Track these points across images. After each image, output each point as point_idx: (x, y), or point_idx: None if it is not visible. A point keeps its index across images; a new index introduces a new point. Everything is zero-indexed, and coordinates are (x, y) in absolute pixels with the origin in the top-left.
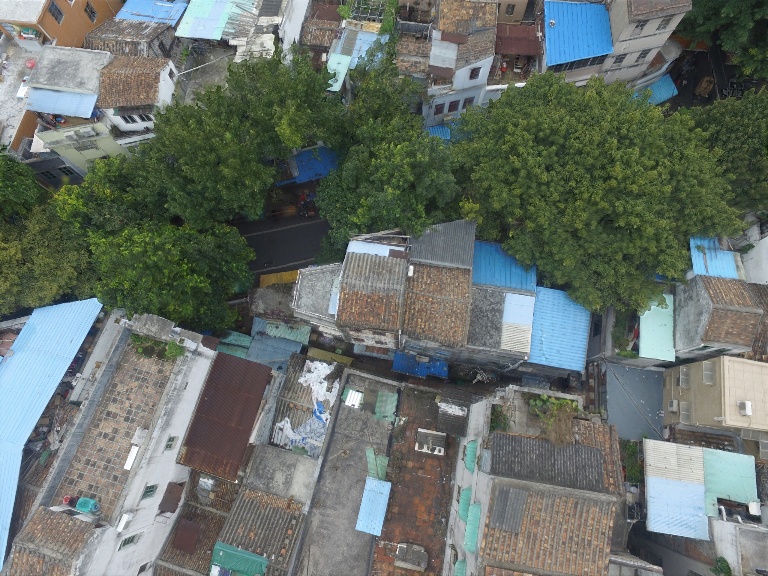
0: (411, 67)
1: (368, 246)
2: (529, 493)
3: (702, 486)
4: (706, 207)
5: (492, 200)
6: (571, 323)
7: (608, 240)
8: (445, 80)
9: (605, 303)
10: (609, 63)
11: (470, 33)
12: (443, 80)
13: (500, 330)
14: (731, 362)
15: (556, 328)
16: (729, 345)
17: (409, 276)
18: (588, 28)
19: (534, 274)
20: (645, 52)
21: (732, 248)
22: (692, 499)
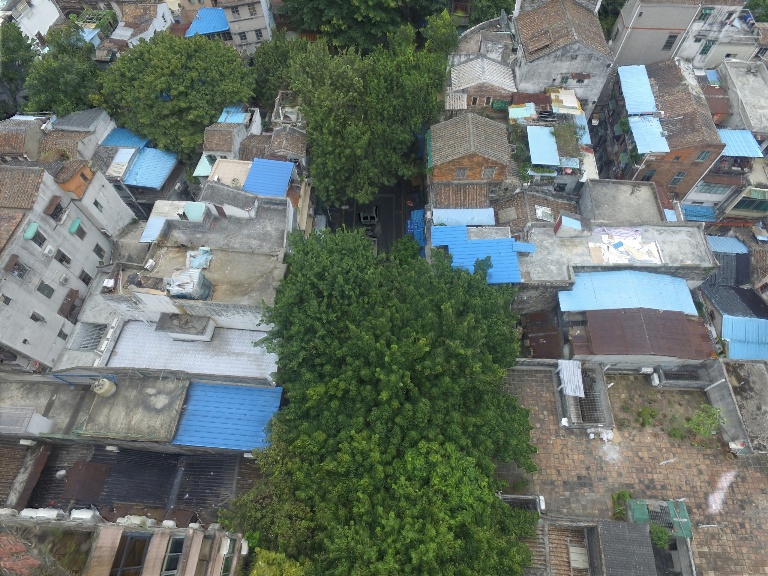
0: (112, 45)
1: (23, 117)
2: (0, 170)
3: None
4: None
5: None
6: (161, 165)
7: None
8: None
9: None
10: (237, 39)
11: (142, 22)
12: None
13: (109, 166)
14: (221, 162)
15: (150, 167)
16: (219, 152)
17: (41, 129)
18: (219, 19)
19: (145, 141)
20: (259, 32)
21: (249, 112)
22: None
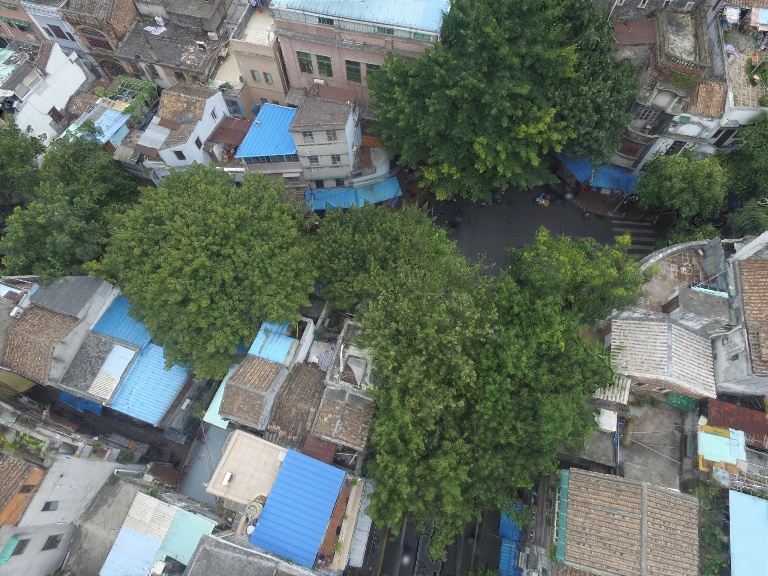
0: None
1: None
2: None
3: (160, 542)
4: (267, 296)
5: (102, 262)
6: (166, 380)
7: (180, 311)
8: (155, 157)
9: (191, 367)
10: (305, 162)
11: (182, 122)
12: (153, 157)
13: (95, 376)
14: (242, 436)
15: (150, 382)
16: (241, 420)
17: (10, 315)
18: (286, 131)
19: None
20: (337, 157)
21: (297, 336)
22: (146, 553)
